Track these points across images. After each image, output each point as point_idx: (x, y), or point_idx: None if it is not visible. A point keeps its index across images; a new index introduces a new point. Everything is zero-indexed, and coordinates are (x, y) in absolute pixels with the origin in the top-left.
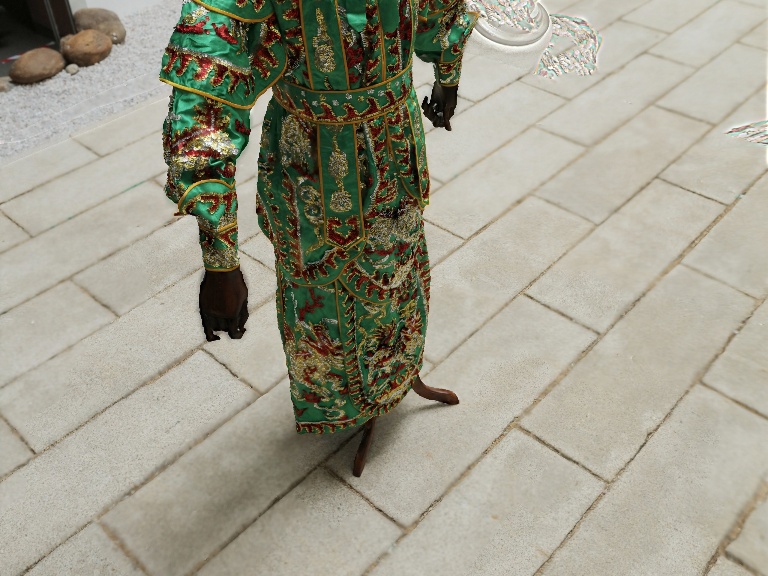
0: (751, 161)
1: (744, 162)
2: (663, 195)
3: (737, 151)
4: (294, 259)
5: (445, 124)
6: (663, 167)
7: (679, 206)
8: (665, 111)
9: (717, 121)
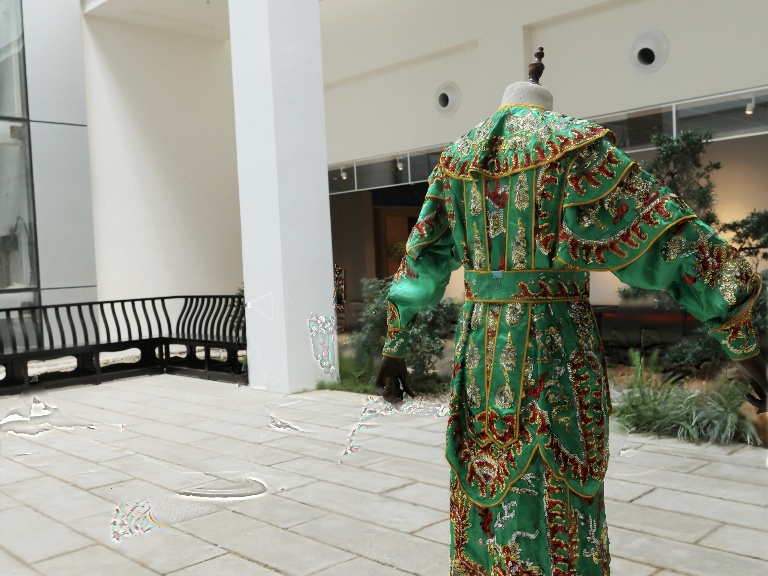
0: (171, 537)
1: (170, 539)
2: (196, 574)
3: (151, 540)
4: (600, 455)
5: (411, 393)
6: (149, 570)
7: (218, 569)
8: (49, 560)
9: (94, 542)
